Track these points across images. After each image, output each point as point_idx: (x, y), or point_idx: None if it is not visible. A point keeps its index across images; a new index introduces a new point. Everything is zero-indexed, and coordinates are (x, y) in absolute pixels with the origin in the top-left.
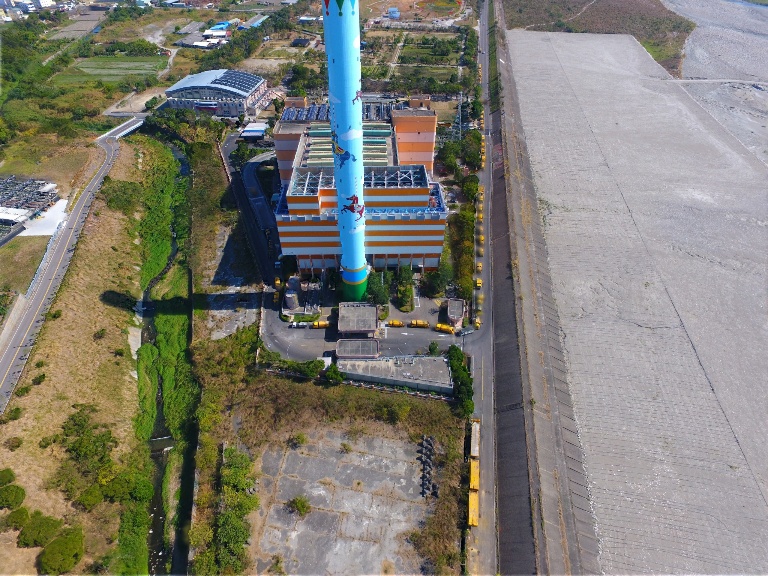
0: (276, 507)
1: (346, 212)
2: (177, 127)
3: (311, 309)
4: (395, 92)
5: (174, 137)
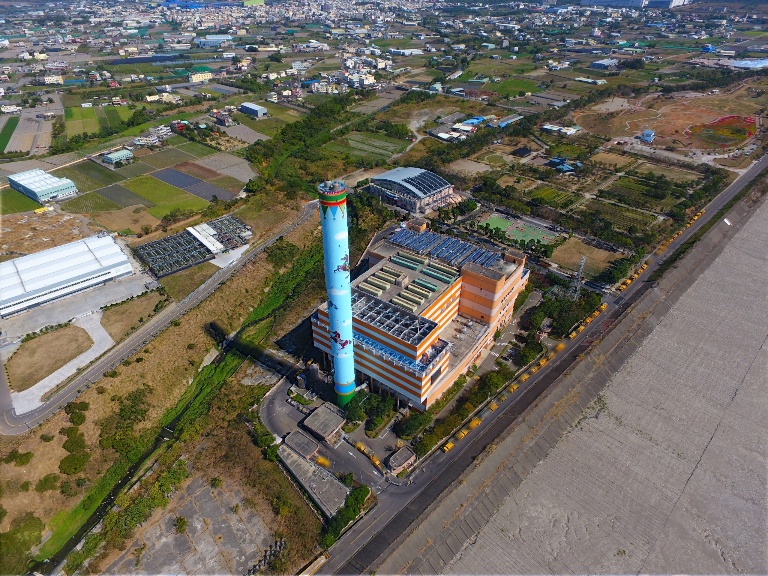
0: (172, 516)
1: (332, 340)
2: (359, 209)
3: (310, 395)
4: (562, 226)
5: (356, 215)
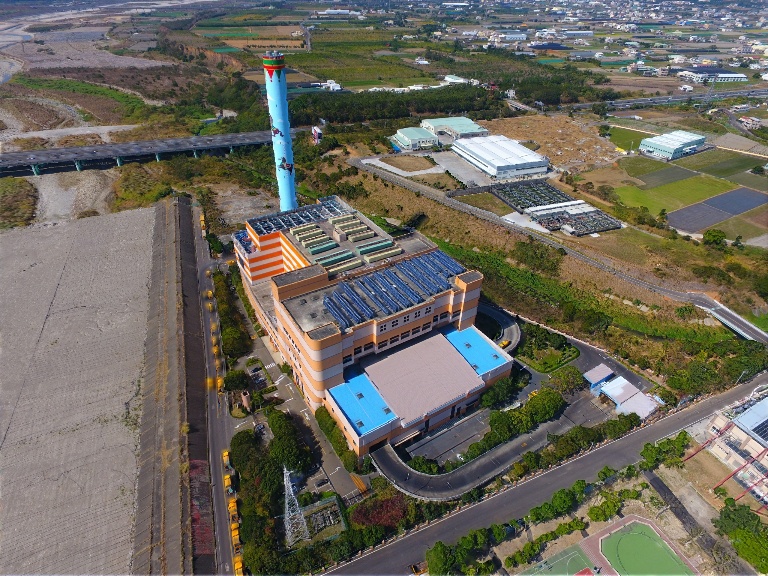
0: None
1: None
2: None
3: None
4: None
5: None
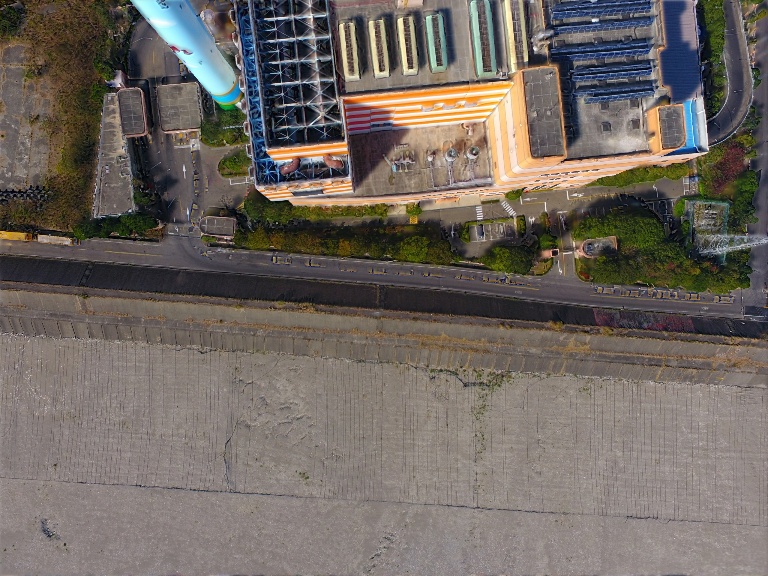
0: None
1: None
2: None
3: None
4: None
5: None
